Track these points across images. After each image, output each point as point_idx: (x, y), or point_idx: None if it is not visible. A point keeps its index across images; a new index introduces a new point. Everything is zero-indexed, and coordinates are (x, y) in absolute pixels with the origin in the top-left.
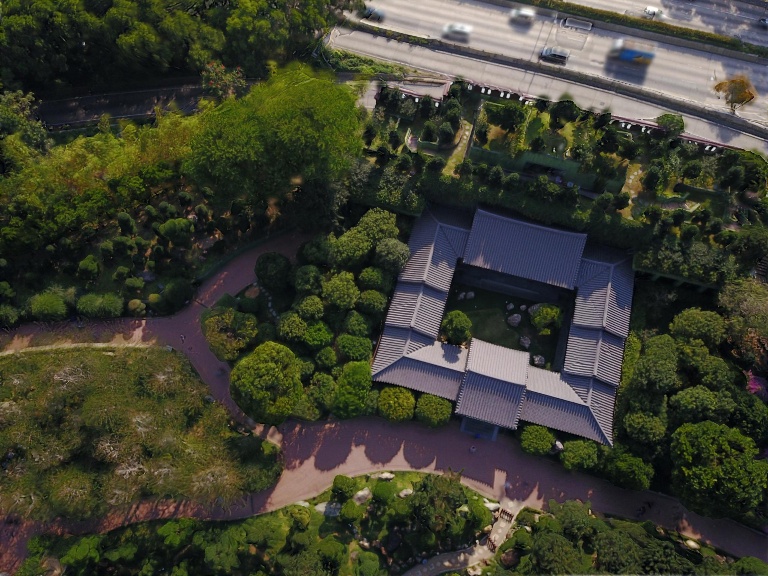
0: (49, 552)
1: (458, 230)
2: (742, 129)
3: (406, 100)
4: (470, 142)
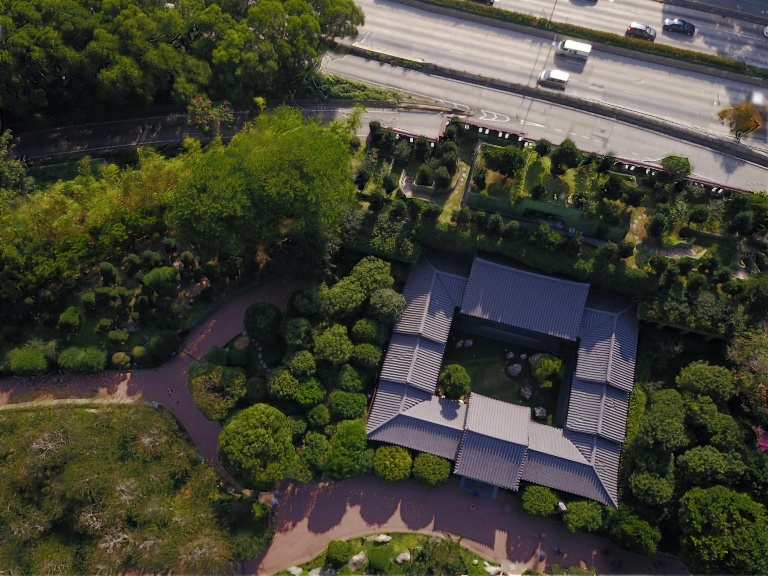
0: None
1: (455, 278)
2: (747, 158)
3: (400, 141)
4: (467, 185)
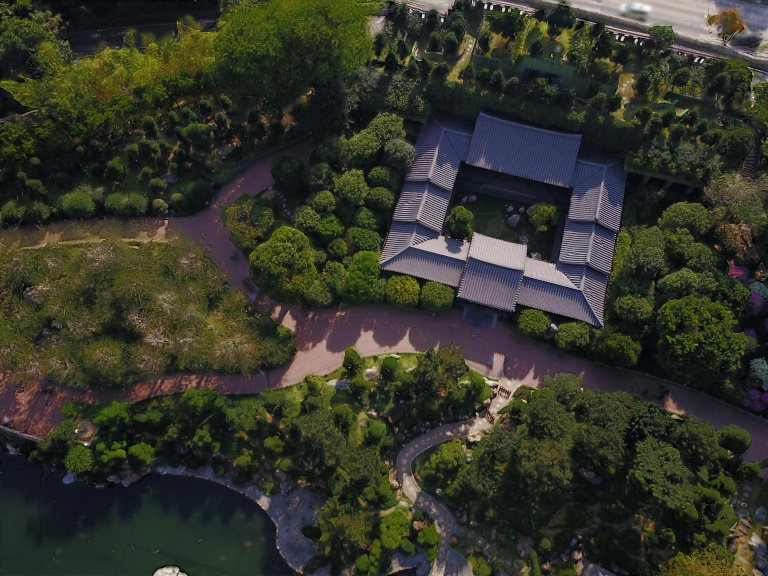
0: (82, 415)
1: (461, 135)
2: None
3: (413, 14)
4: None
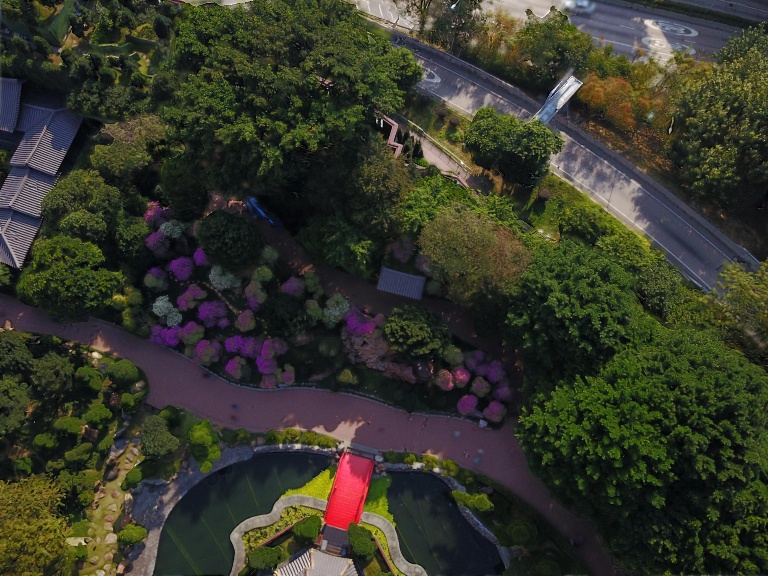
0: None
1: None
2: None
3: None
4: None
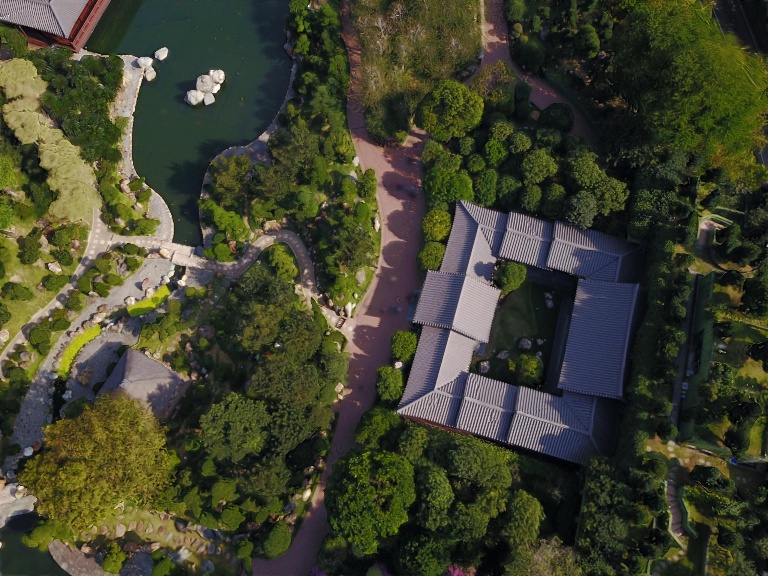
0: None
1: (616, 275)
2: None
3: (767, 211)
4: None
